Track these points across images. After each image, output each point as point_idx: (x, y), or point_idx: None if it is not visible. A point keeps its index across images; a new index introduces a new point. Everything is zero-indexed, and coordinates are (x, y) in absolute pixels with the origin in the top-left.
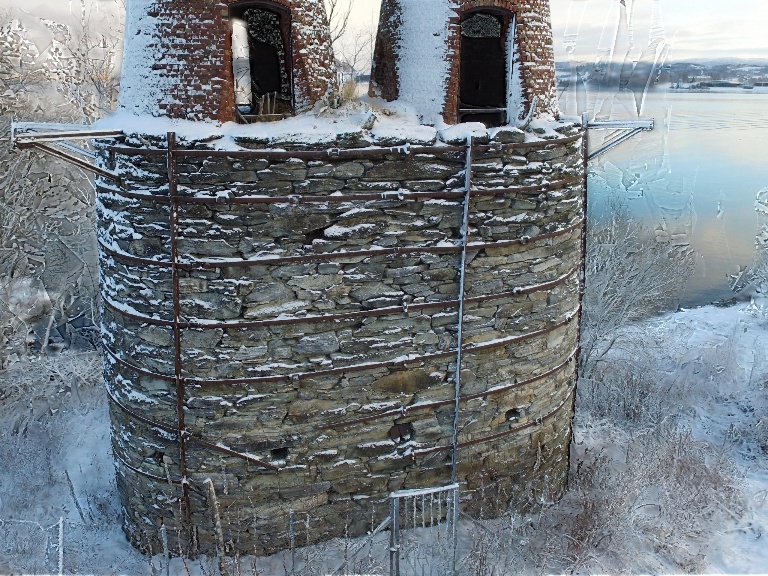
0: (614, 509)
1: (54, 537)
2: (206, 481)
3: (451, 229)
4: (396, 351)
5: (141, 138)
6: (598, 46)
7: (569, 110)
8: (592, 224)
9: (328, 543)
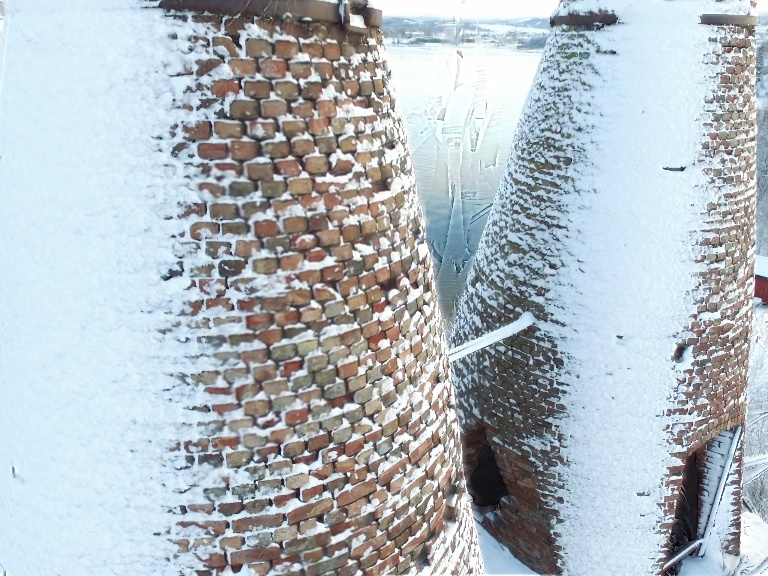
0: None
1: None
2: None
3: None
4: None
5: None
6: (428, 92)
7: (455, 210)
8: None
9: None
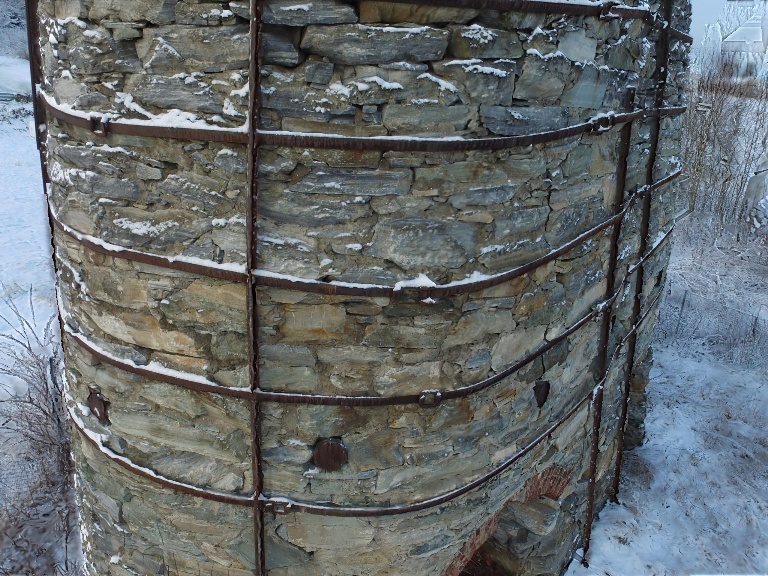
0: None
1: None
2: None
3: None
4: None
5: None
6: None
7: None
8: None
9: None
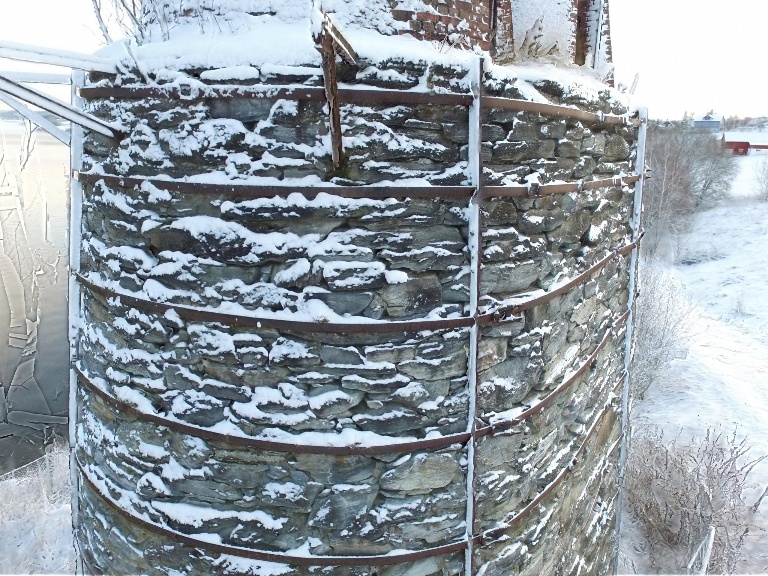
0: None
1: None
2: None
3: None
4: (606, 389)
5: (435, 66)
6: None
7: None
8: None
9: None
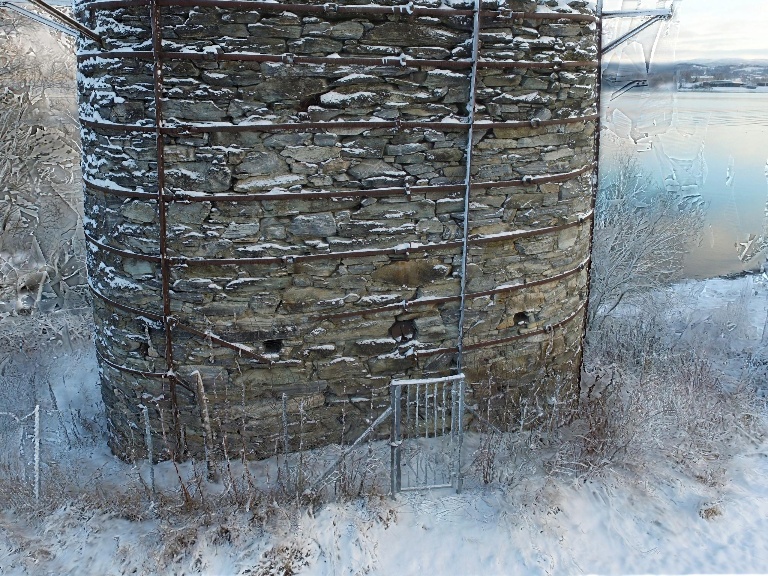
0: (630, 416)
1: (30, 427)
2: (194, 373)
3: (457, 107)
4: (398, 238)
5: None
6: (605, 8)
7: None
8: (599, 179)
9: (325, 448)
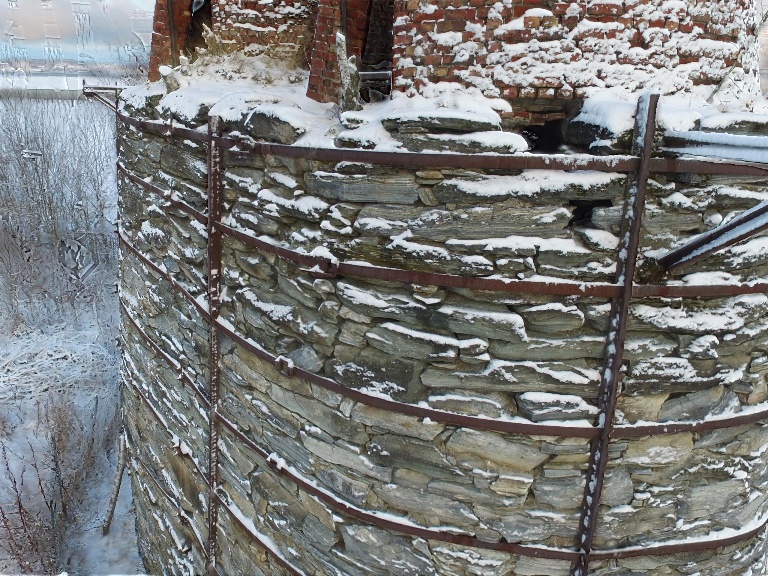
0: None
1: None
2: None
3: None
4: None
5: None
6: None
7: None
8: None
9: None
